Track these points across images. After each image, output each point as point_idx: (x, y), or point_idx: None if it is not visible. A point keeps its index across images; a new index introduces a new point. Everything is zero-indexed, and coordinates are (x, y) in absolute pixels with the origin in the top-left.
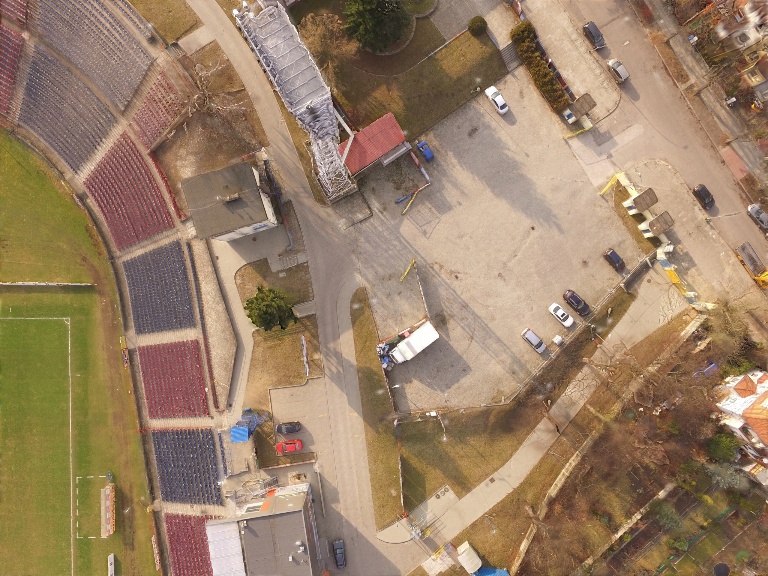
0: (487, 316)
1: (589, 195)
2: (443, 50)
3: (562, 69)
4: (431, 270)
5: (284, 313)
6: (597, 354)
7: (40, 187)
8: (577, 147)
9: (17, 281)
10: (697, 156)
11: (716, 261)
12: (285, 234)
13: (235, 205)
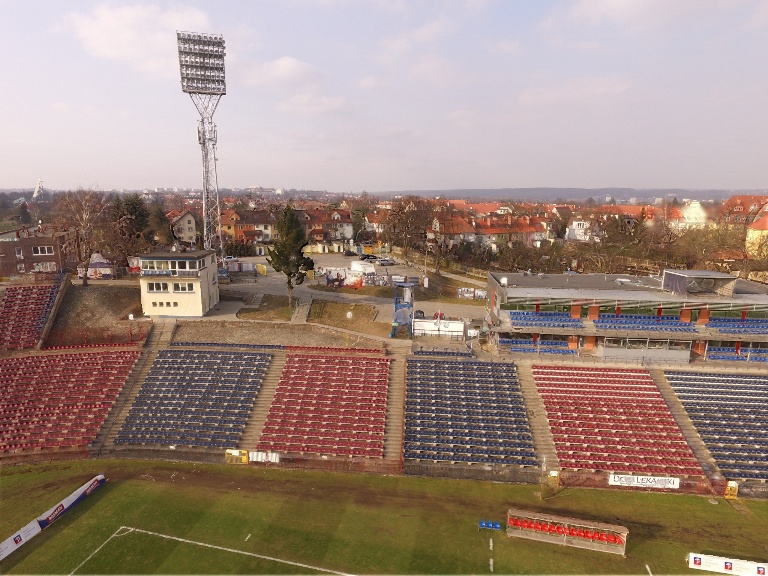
0: None
1: None
2: None
3: None
4: None
5: None
6: None
7: None
8: None
9: None
10: None
11: None
12: None
13: None
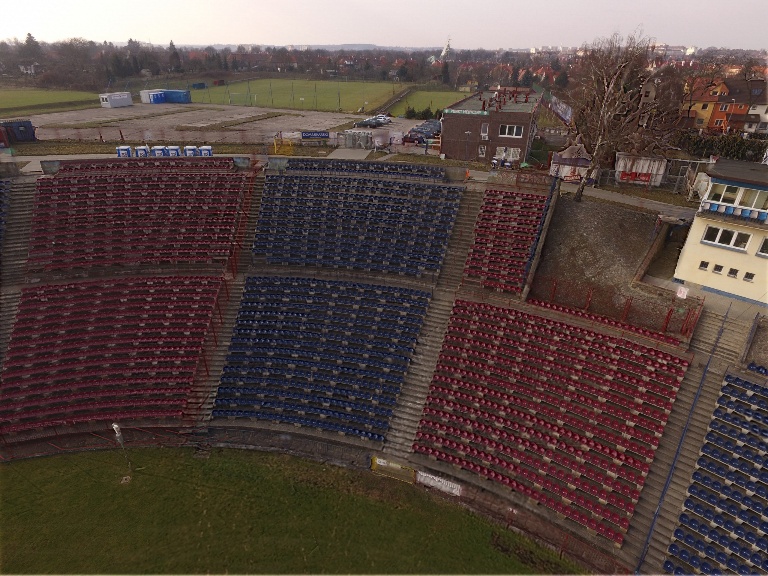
0: None
1: None
2: None
3: None
4: None
5: None
6: None
7: (319, 517)
8: None
9: None
10: None
11: None
12: None
13: None
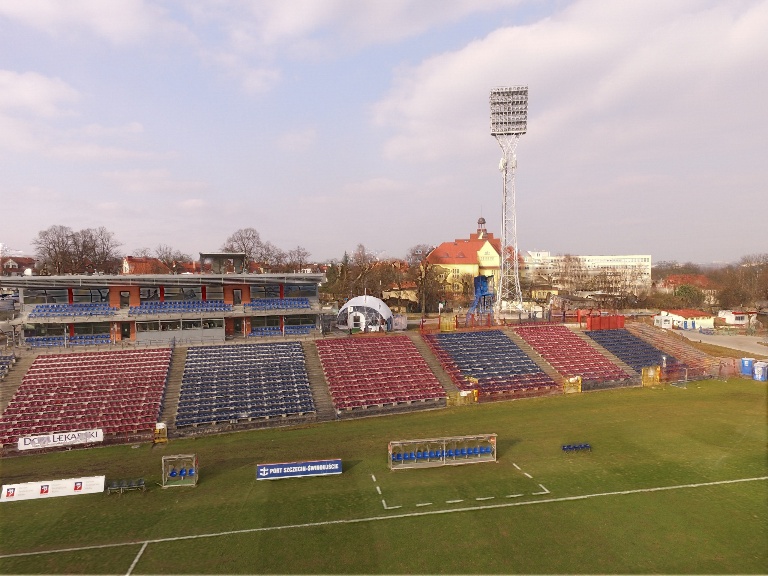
0: None
1: None
2: None
3: None
4: None
5: None
6: None
7: None
8: None
9: None
10: None
11: None
12: None
13: None
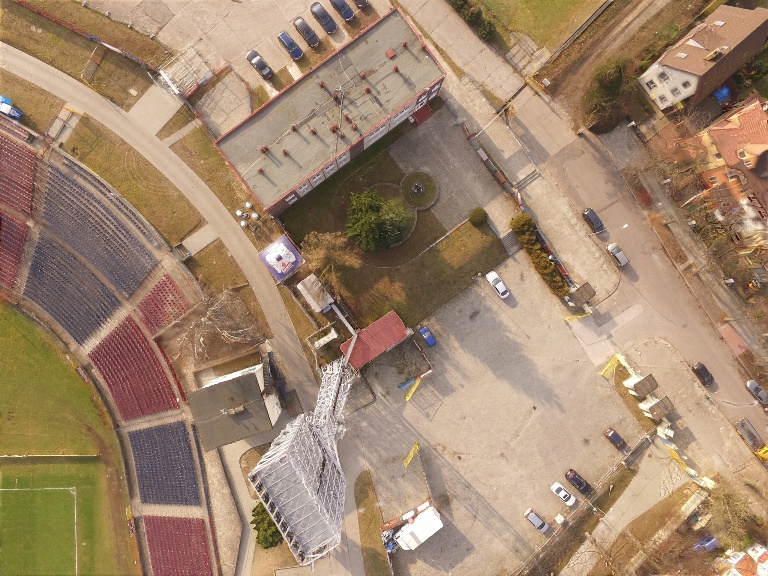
0: (490, 496)
1: (590, 374)
2: (444, 241)
3: (562, 253)
4: (434, 452)
5: None
6: (599, 527)
7: (45, 359)
8: (577, 328)
9: (23, 452)
10: (696, 334)
11: (716, 435)
12: (289, 418)
13: (240, 416)
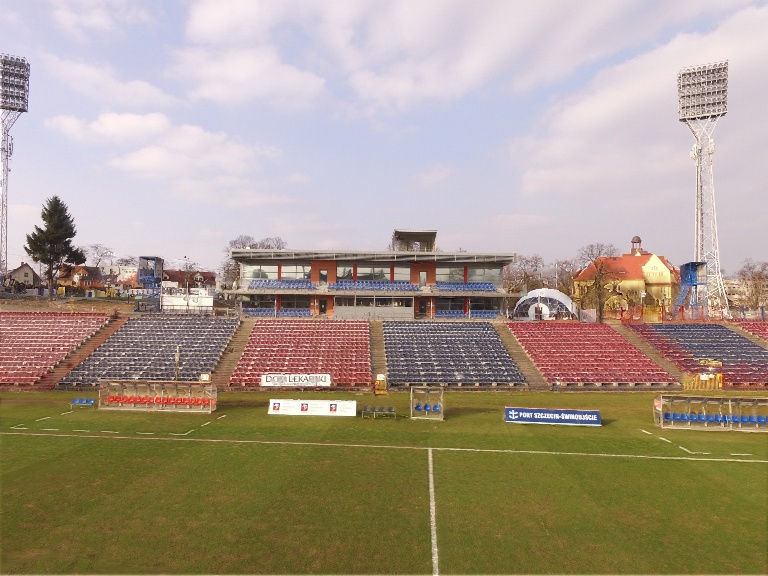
0: None
1: None
2: None
3: None
4: None
5: (68, 248)
6: None
7: None
8: None
9: None
10: None
11: None
12: None
13: None
